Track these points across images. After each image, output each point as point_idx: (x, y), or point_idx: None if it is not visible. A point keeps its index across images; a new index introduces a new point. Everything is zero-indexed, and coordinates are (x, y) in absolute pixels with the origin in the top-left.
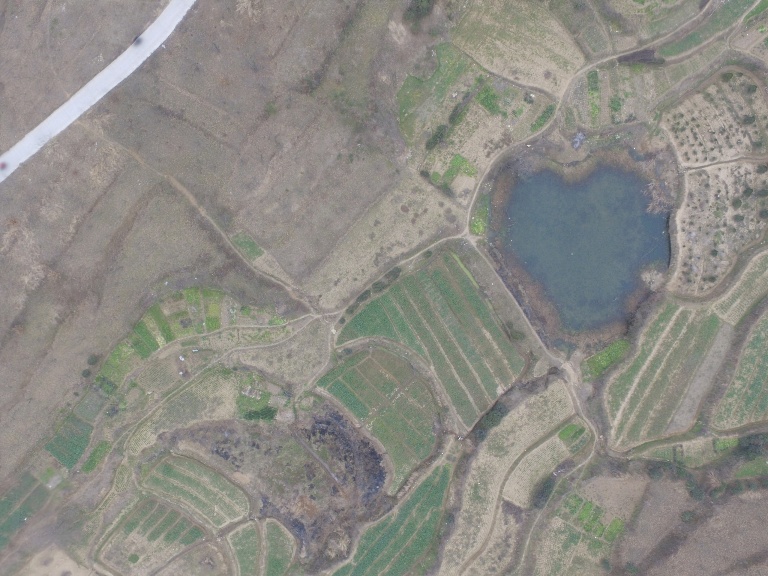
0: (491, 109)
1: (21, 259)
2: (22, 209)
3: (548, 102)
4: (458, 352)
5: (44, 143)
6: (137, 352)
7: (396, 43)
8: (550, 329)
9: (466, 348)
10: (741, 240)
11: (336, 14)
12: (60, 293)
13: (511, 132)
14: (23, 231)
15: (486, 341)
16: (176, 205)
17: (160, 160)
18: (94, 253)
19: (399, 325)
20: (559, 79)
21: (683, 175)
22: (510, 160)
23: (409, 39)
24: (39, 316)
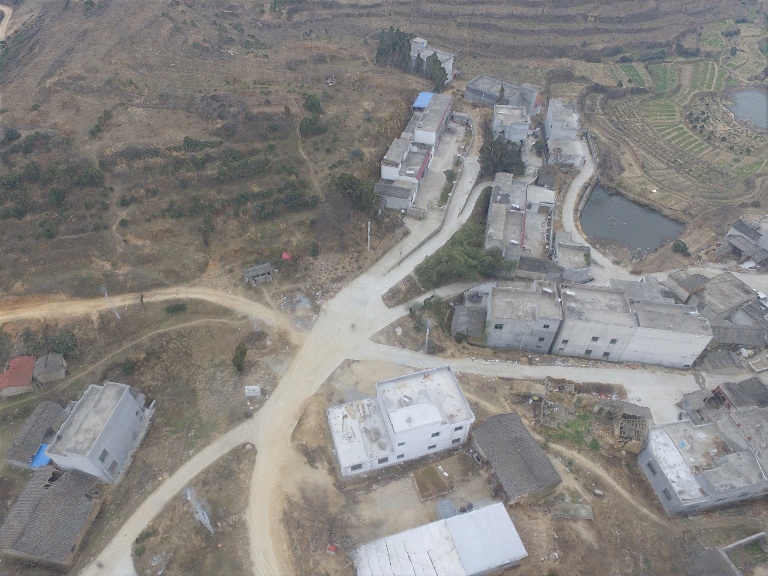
0: None
1: None
2: None
3: None
4: None
5: None
6: None
7: None
8: None
9: None
10: None
11: None
12: None
13: None
14: None
15: None
16: None
17: None
18: None
19: None
20: None
21: None
22: None
23: None
24: None
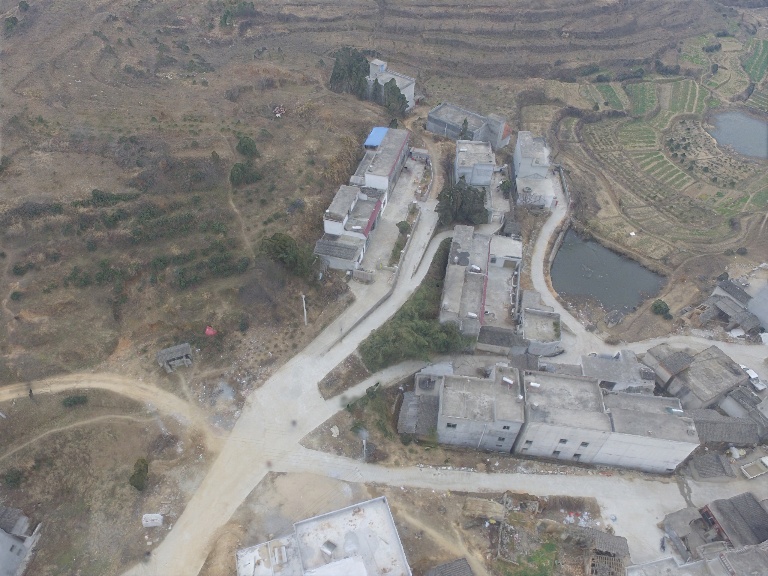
0: None
1: None
2: None
3: None
4: None
5: None
6: None
7: None
8: None
9: None
10: None
11: None
12: None
13: None
14: None
15: None
16: None
17: None
18: None
19: None
20: None
21: None
22: None
23: None
24: None
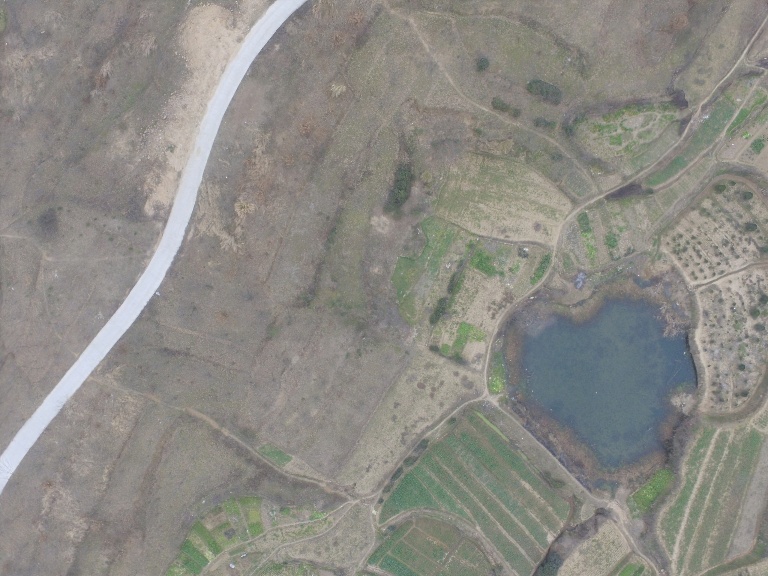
0: (487, 271)
1: (63, 517)
2: (54, 471)
3: (543, 252)
4: (501, 508)
5: (63, 404)
6: (188, 571)
7: (381, 234)
8: (589, 471)
9: (508, 503)
10: (766, 348)
11: (318, 227)
12: (105, 538)
13: (512, 289)
14: (59, 491)
15: (527, 492)
16: (199, 431)
17: (176, 397)
18: (130, 495)
19: (437, 493)
20: (549, 229)
21: (694, 294)
22: (516, 314)
23: (393, 226)
24: (90, 564)
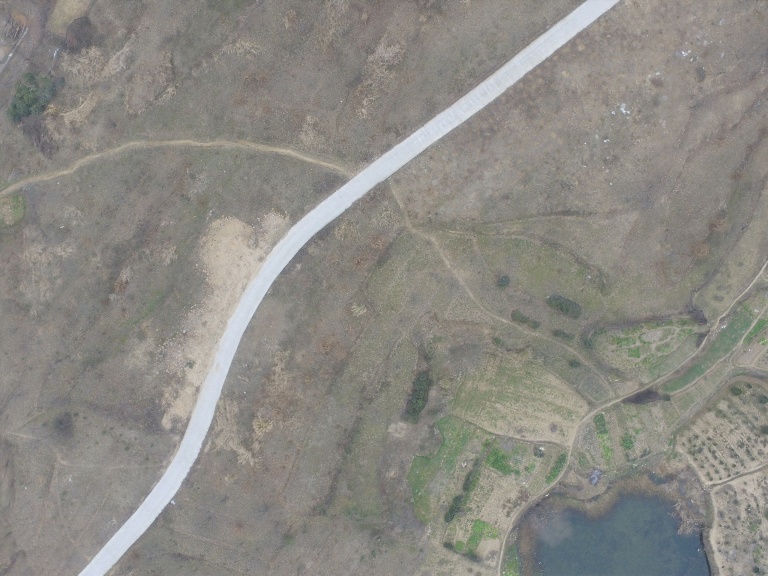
0: (503, 470)
1: None
2: None
3: (559, 451)
4: None
5: None
6: None
7: (398, 438)
8: None
9: None
10: None
11: (335, 439)
12: None
13: (527, 488)
14: None
15: None
16: None
17: None
18: None
19: None
20: (566, 430)
21: (709, 494)
22: (530, 509)
23: (410, 429)
24: None
